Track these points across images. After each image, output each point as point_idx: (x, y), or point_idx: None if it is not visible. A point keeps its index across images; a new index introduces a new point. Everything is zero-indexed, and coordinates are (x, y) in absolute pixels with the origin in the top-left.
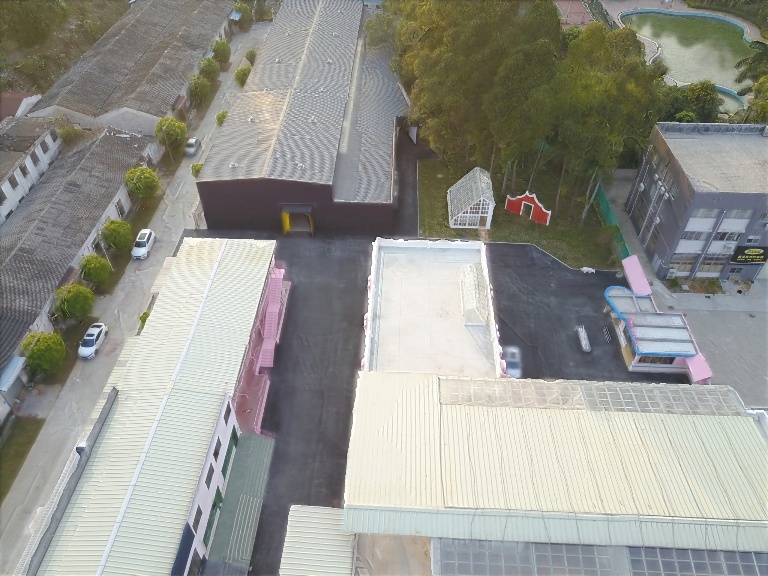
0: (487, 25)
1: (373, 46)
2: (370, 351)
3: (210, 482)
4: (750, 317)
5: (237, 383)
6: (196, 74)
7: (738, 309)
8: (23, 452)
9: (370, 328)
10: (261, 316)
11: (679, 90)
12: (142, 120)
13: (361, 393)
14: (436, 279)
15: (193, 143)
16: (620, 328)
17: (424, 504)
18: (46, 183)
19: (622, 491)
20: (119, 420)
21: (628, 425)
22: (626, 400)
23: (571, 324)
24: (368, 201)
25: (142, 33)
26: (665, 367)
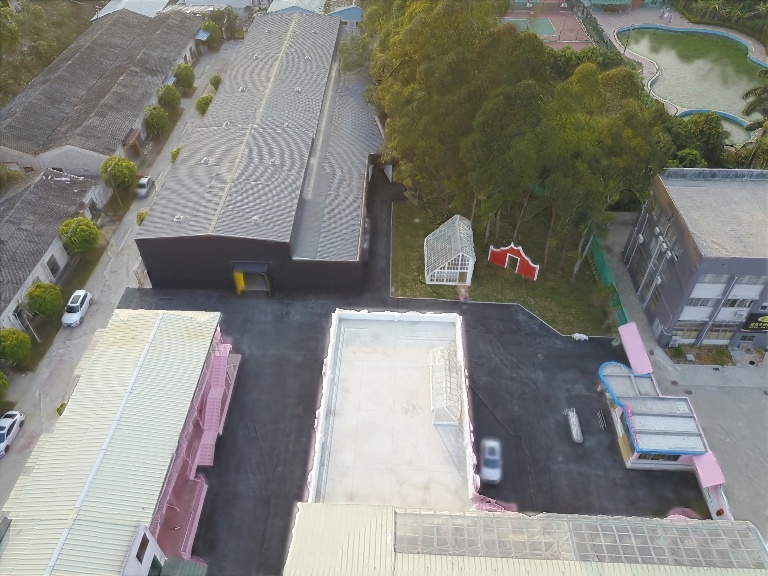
0: (464, 61)
1: (347, 71)
2: (320, 461)
3: None
4: (765, 395)
5: (157, 507)
6: (154, 103)
7: (751, 385)
8: None
9: (321, 430)
10: (200, 404)
11: (681, 123)
12: (88, 158)
13: (298, 536)
14: (403, 362)
15: (145, 183)
16: (616, 413)
17: None
18: None
19: None
20: (6, 564)
21: None
22: (623, 544)
23: (560, 406)
24: (332, 258)
25: (98, 56)
26: (669, 464)
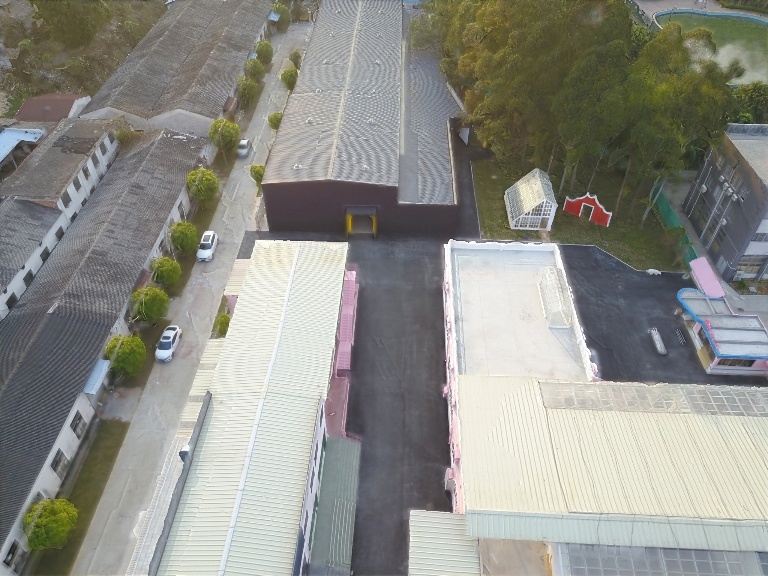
0: (555, 26)
1: (418, 47)
2: (457, 354)
3: (312, 486)
4: None
5: None
6: (242, 75)
7: None
8: (111, 456)
9: (455, 331)
10: None
11: (732, 91)
12: (195, 121)
13: (464, 397)
14: (513, 281)
15: (245, 144)
16: (694, 330)
17: (547, 509)
18: (108, 185)
19: (744, 496)
20: (217, 424)
21: (737, 429)
22: (730, 404)
23: (643, 326)
24: (432, 203)
25: (184, 34)
26: (744, 370)
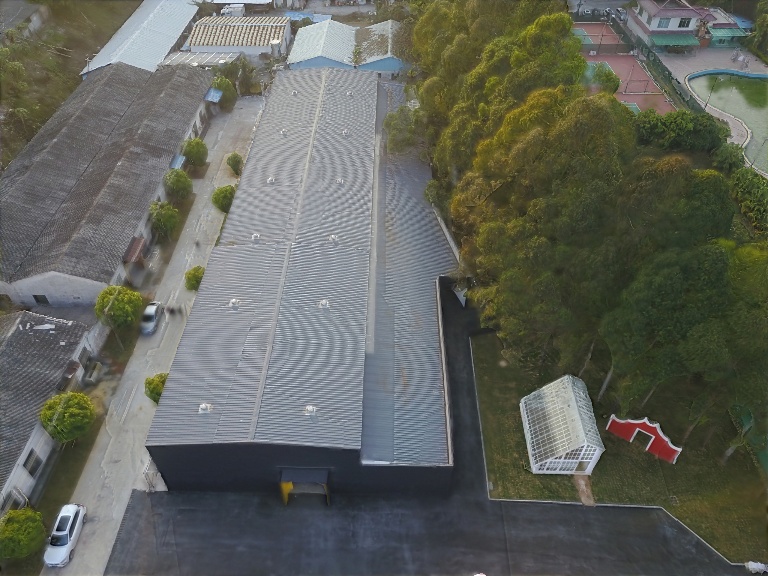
0: (606, 201)
1: (397, 152)
2: None
3: None
4: None
5: None
6: (160, 194)
7: None
8: None
9: None
10: None
11: None
12: (78, 285)
13: None
14: None
15: (152, 314)
16: None
17: None
18: None
19: None
20: None
21: None
22: None
23: None
24: (415, 459)
25: (90, 129)
26: None
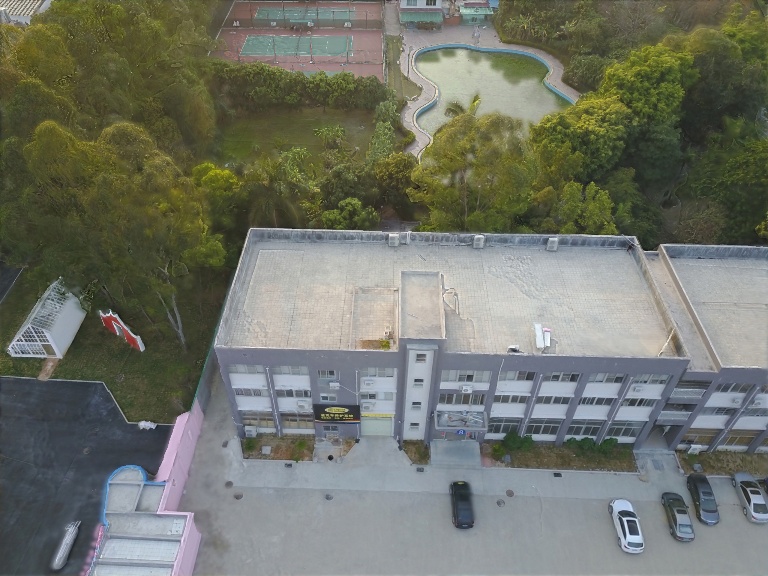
0: None
1: None
2: None
3: None
4: (325, 499)
5: None
6: None
7: (316, 486)
8: None
9: None
10: None
11: None
12: None
13: None
14: None
15: None
16: None
17: None
18: None
19: None
20: None
21: None
22: None
23: (67, 518)
24: None
25: None
26: None
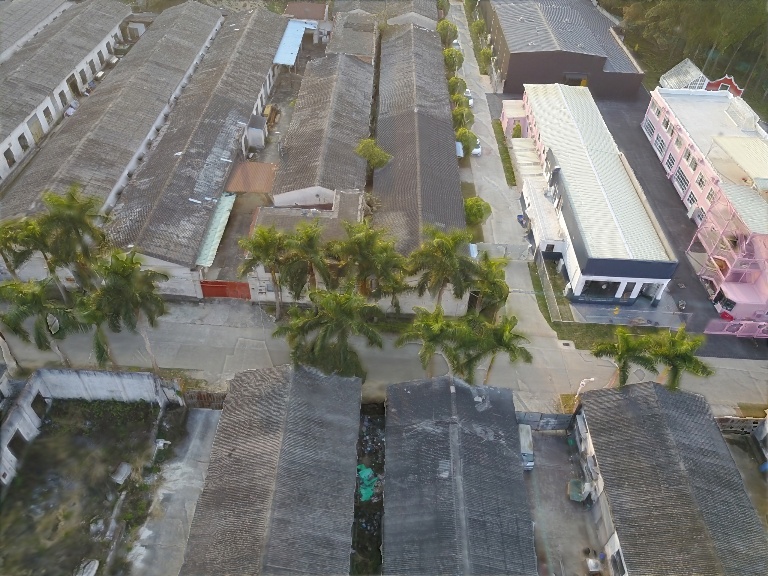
0: None
1: None
2: None
3: None
4: None
5: None
6: None
7: None
8: None
9: None
10: None
11: None
12: (421, 23)
13: (721, 143)
14: (707, 110)
15: (457, 43)
16: None
17: None
18: (391, 55)
19: None
20: (564, 162)
21: None
22: None
23: None
24: None
25: None
26: None
